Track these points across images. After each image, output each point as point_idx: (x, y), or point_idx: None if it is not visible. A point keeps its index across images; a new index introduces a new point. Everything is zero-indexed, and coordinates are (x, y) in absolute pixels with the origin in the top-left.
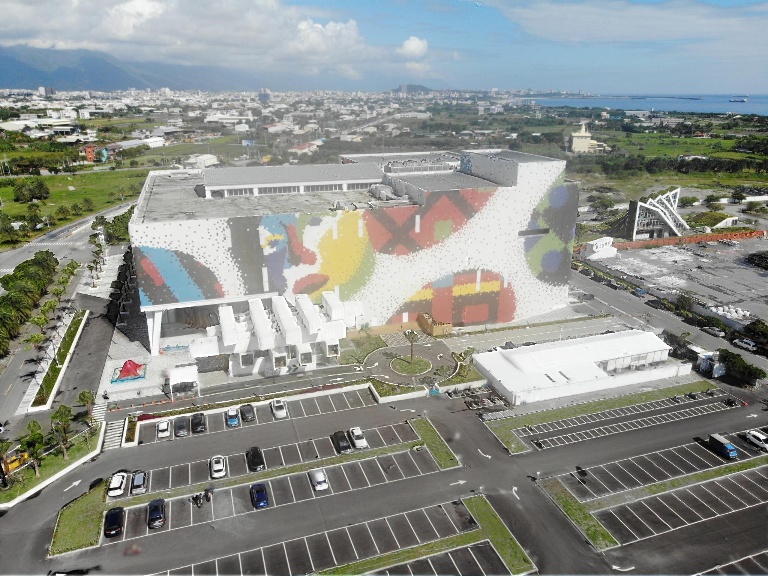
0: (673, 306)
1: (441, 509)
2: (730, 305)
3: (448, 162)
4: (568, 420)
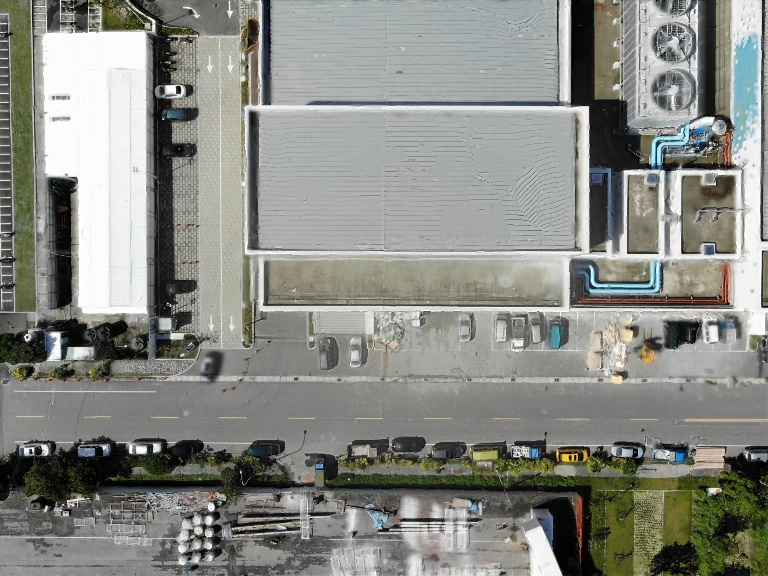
0: (234, 460)
1: None
2: (210, 558)
3: (760, 173)
4: (8, 86)
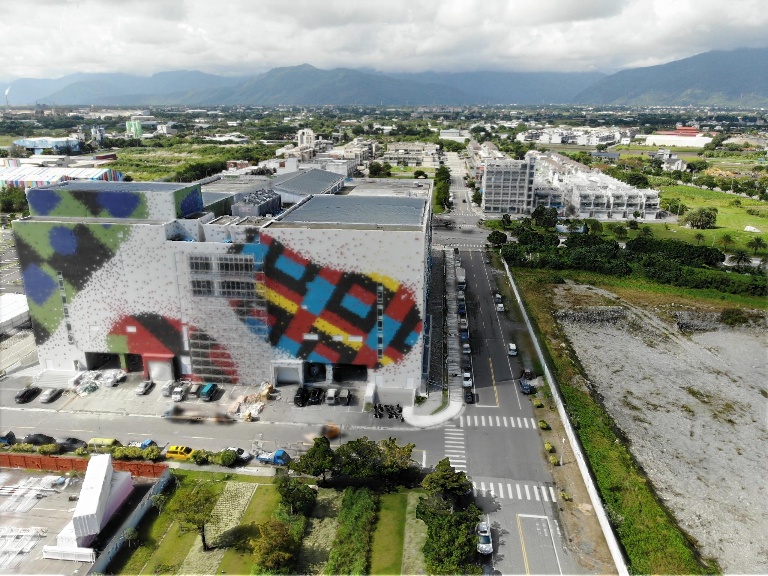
0: None
1: (1, 276)
2: None
3: (281, 215)
4: None
